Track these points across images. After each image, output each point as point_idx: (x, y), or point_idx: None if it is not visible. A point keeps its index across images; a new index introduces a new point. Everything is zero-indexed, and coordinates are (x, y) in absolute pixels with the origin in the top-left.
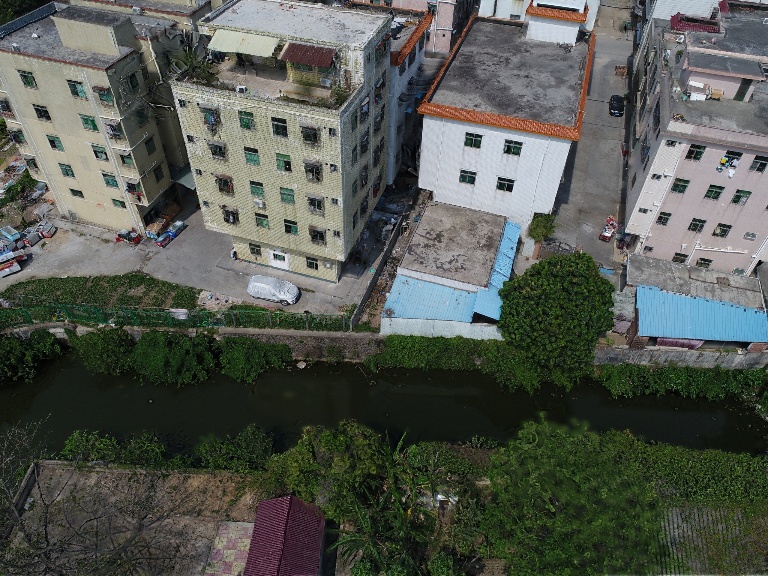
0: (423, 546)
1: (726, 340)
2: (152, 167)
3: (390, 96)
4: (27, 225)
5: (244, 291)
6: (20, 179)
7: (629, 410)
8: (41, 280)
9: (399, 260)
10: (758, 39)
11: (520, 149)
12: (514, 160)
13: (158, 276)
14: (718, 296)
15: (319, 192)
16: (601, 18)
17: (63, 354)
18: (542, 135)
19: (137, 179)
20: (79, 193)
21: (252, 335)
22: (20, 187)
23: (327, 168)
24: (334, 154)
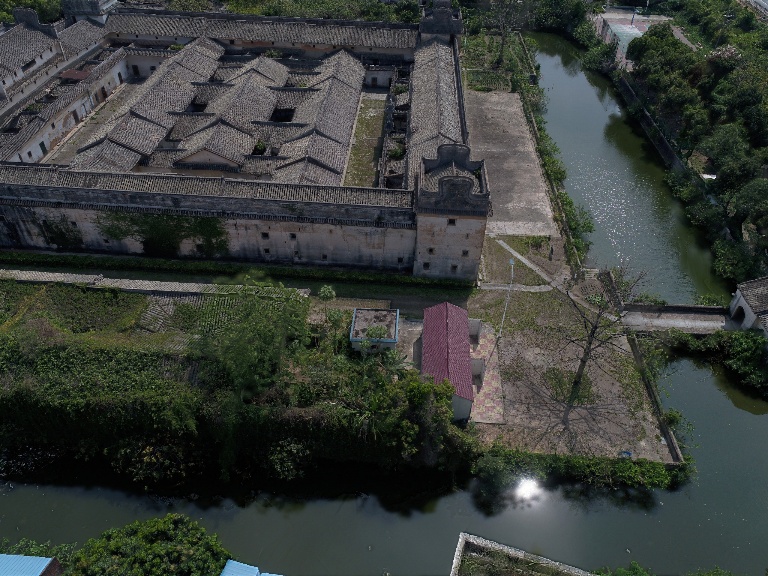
0: None
1: None
2: None
3: None
4: None
5: None
6: None
7: None
8: None
9: None
10: None
11: None
12: None
13: None
14: None
15: None
16: None
17: None
18: None
19: None
20: None
21: None
22: None
23: None
24: None
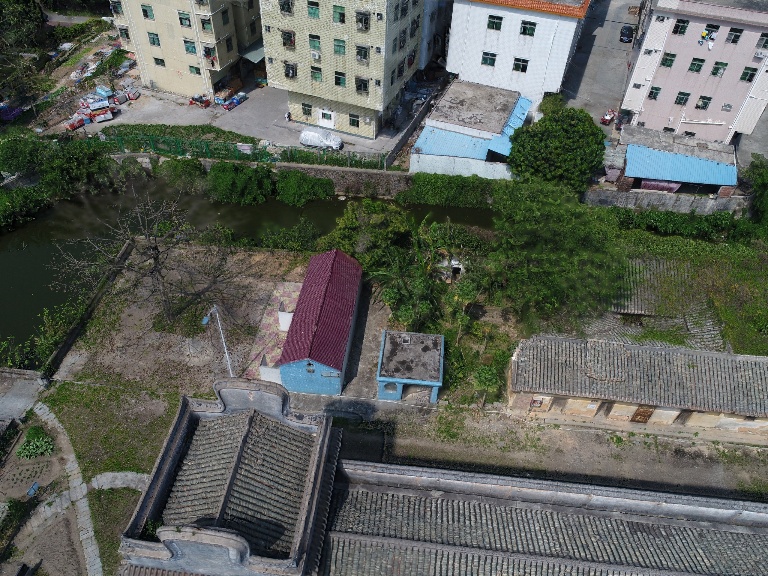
0: (438, 300)
1: (699, 182)
2: (225, 37)
3: None
4: (115, 91)
5: (296, 141)
6: (108, 60)
7: None
8: (130, 125)
9: None
10: None
11: (534, 30)
12: (529, 40)
13: (225, 129)
14: (696, 154)
15: (366, 42)
16: None
17: (147, 180)
18: (553, 15)
19: (213, 44)
20: (161, 62)
21: (303, 169)
22: (108, 64)
23: (374, 17)
24: (381, 3)
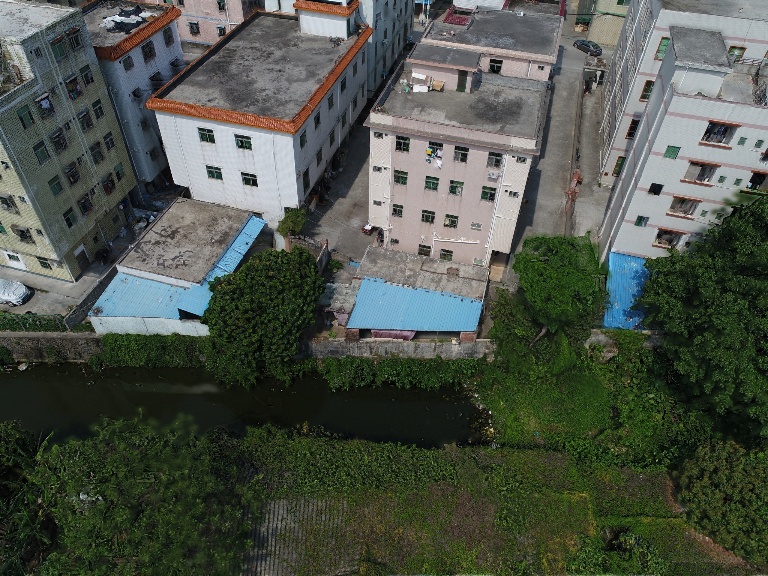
0: (63, 547)
1: (434, 330)
2: None
3: (119, 92)
4: None
5: None
6: None
7: (345, 403)
8: None
9: None
10: (501, 31)
11: (251, 143)
12: (249, 155)
13: None
14: (442, 287)
15: (5, 190)
16: (383, 12)
17: None
18: (264, 129)
19: None
20: None
21: None
22: None
23: None
24: None
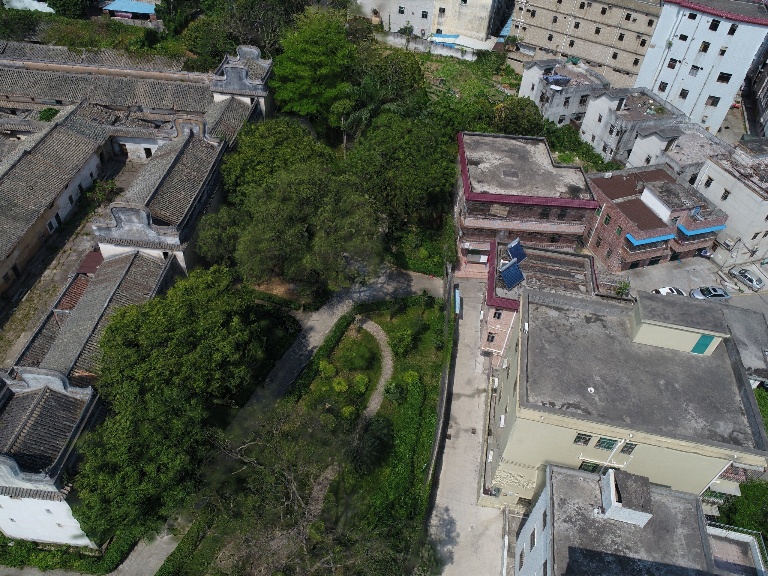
0: None
1: (138, 12)
2: None
3: None
4: None
5: None
6: None
7: None
8: None
9: None
10: None
11: None
12: None
13: None
14: None
15: None
16: None
17: None
18: None
19: None
20: None
21: None
22: None
23: None
24: None
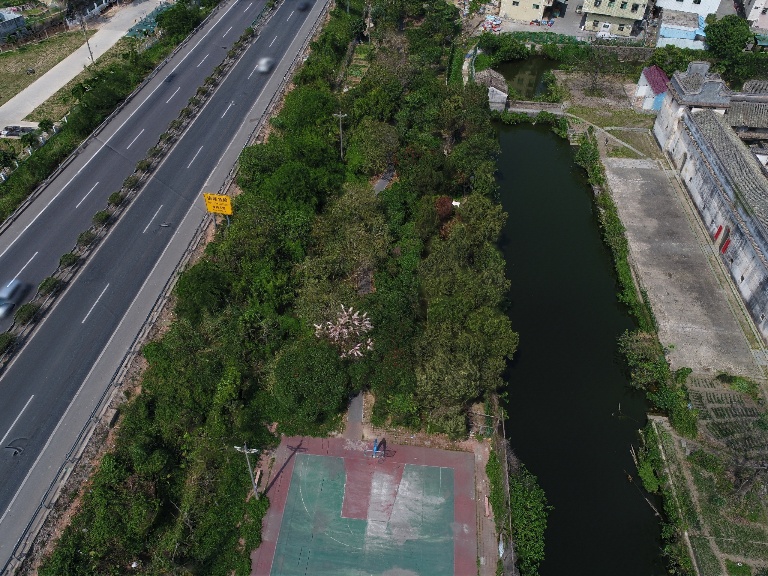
0: None
1: None
2: None
3: None
4: None
5: (593, 38)
6: (470, 6)
7: None
8: None
9: (650, 33)
10: None
11: None
12: None
13: None
14: None
15: None
16: None
17: None
18: None
19: None
20: (517, 3)
21: (605, 48)
22: None
23: None
24: None
